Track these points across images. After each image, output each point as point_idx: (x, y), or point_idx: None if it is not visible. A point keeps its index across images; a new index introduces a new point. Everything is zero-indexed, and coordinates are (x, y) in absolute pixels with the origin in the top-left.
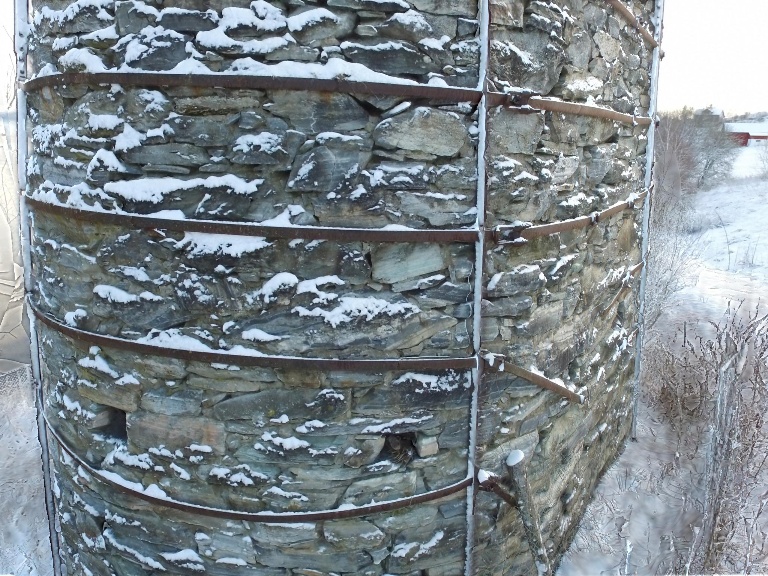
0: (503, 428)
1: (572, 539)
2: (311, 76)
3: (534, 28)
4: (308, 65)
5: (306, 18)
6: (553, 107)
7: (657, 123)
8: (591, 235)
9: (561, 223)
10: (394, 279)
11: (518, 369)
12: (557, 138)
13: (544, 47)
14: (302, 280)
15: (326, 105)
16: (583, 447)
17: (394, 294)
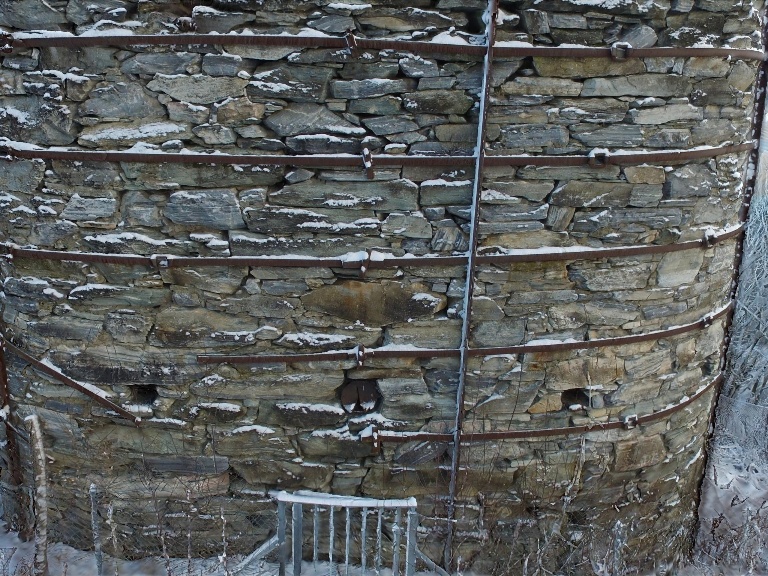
0: (29, 393)
1: (181, 556)
2: None
3: (32, 93)
4: None
5: None
6: (52, 156)
7: (588, 161)
8: (178, 277)
9: (79, 254)
10: None
11: (20, 352)
12: None
13: (40, 107)
14: None
15: None
16: (229, 491)
17: None
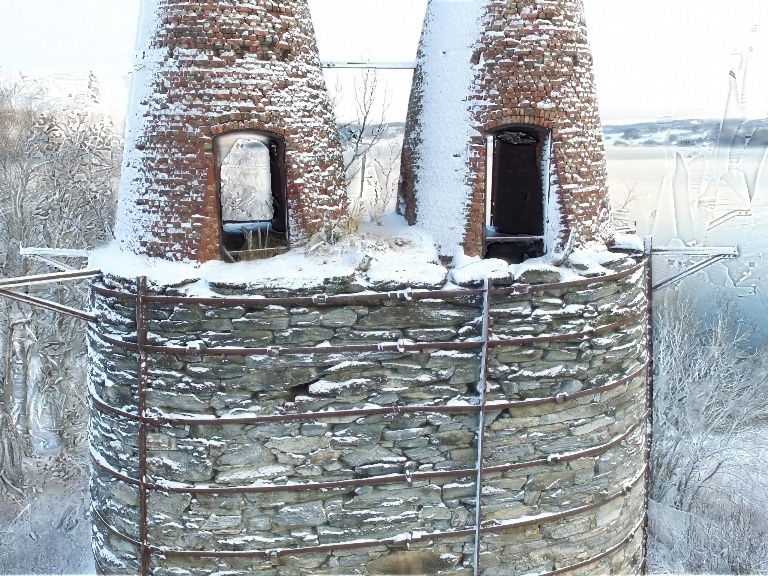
0: None
1: None
2: None
3: None
4: None
5: None
6: (197, 491)
7: (547, 463)
8: (283, 561)
9: (214, 552)
10: None
11: None
12: None
13: None
14: None
15: None
16: None
17: None
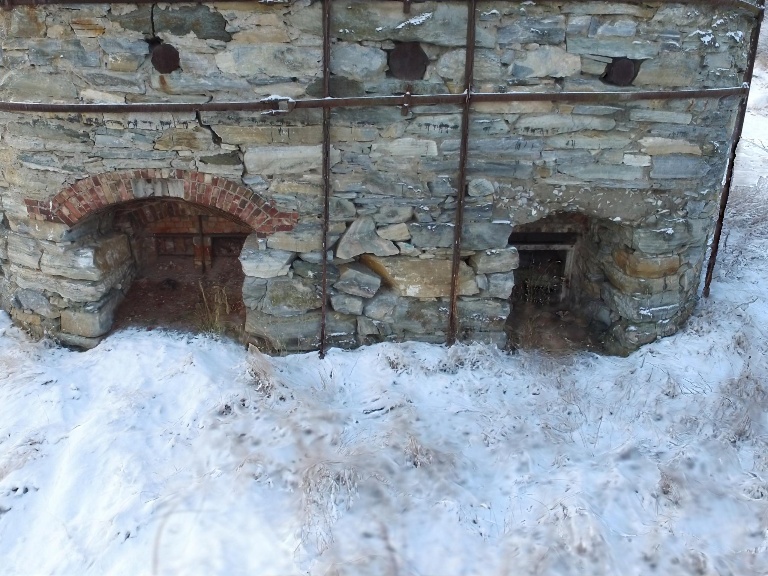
0: None
1: None
2: None
3: None
4: None
5: None
6: None
7: None
8: None
9: None
10: None
11: None
12: None
13: None
14: None
15: None
16: None
17: None
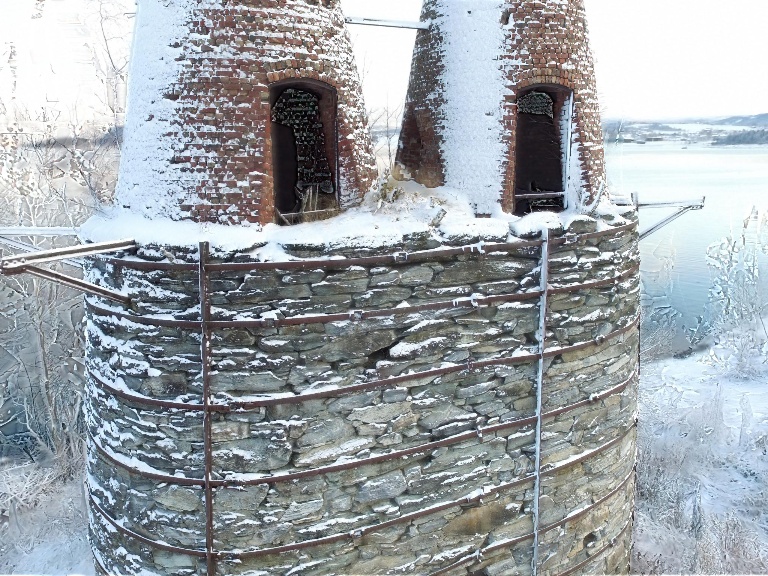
0: None
1: None
2: (125, 464)
3: (257, 437)
4: (125, 458)
5: (124, 436)
6: (276, 480)
7: (589, 402)
8: (365, 540)
9: (295, 544)
10: (167, 565)
11: None
12: (286, 495)
13: (266, 447)
14: (129, 553)
15: (132, 477)
16: None
17: (167, 573)
